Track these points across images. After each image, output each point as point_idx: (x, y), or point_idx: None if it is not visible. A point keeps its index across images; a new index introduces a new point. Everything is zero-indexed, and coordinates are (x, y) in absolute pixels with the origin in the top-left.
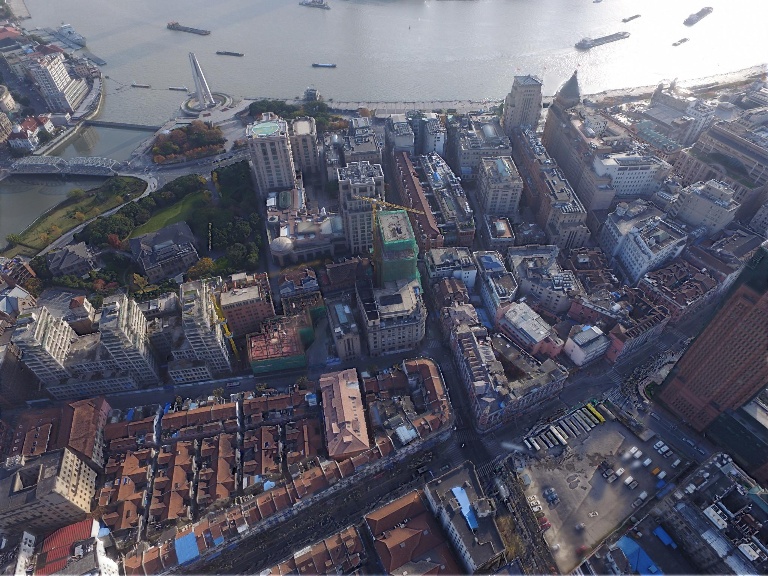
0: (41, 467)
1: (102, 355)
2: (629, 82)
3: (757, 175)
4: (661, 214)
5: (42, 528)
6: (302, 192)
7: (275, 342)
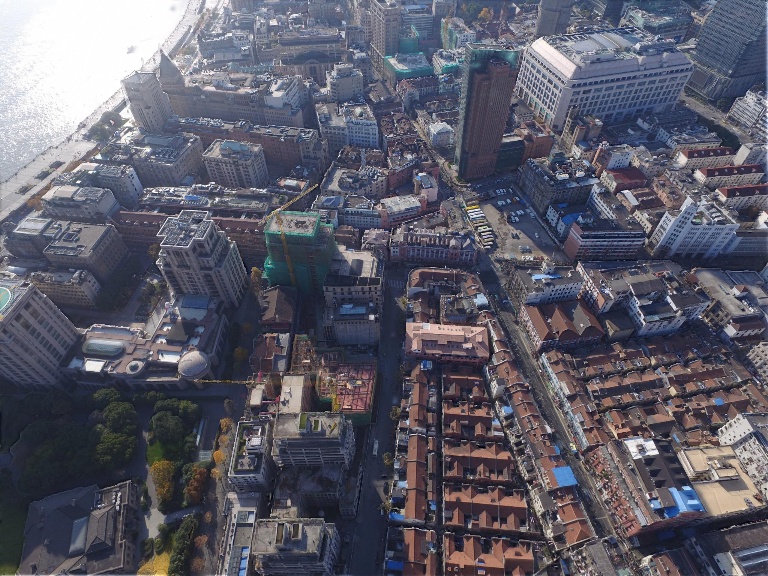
0: None
1: None
2: (140, 56)
3: (333, 53)
4: (335, 104)
5: None
6: (104, 326)
7: None
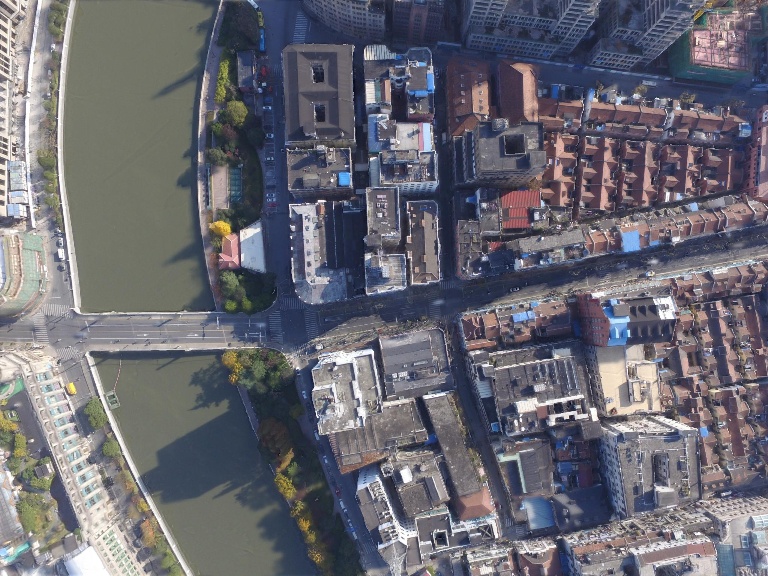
0: (524, 137)
1: (541, 9)
2: None
3: None
4: None
5: (490, 185)
6: None
7: (723, 46)
